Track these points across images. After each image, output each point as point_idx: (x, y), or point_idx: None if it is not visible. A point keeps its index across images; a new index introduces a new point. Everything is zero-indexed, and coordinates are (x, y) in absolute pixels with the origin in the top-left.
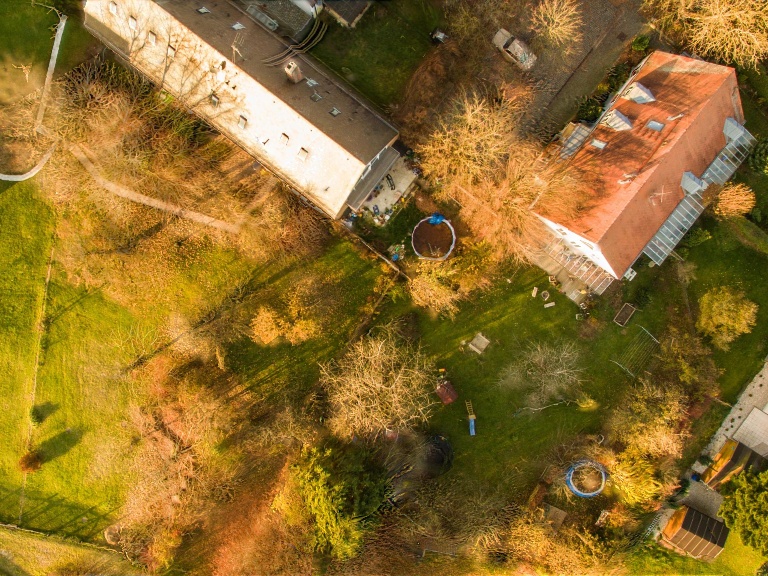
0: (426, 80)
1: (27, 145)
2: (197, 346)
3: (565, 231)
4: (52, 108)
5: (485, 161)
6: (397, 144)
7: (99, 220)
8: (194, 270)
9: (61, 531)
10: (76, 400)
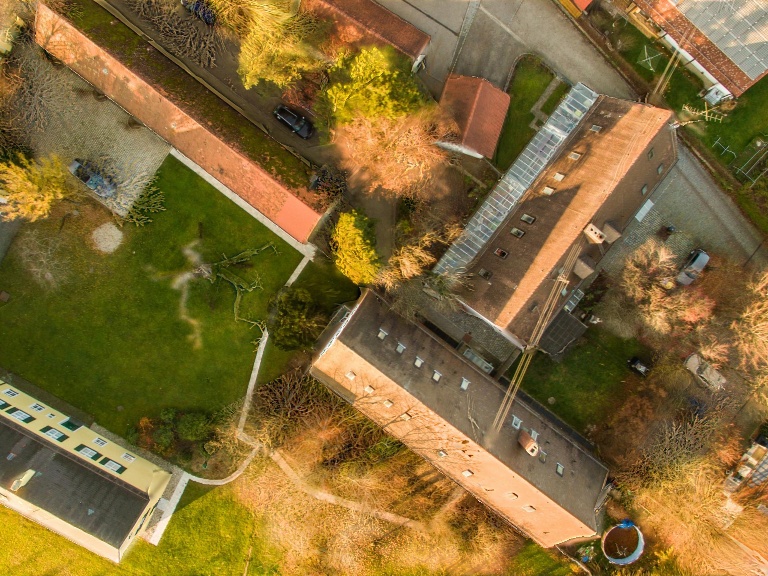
0: (638, 426)
1: (228, 452)
2: None
3: (763, 561)
4: (253, 417)
5: (677, 477)
6: (607, 482)
7: (297, 521)
8: (389, 568)
9: None
10: None
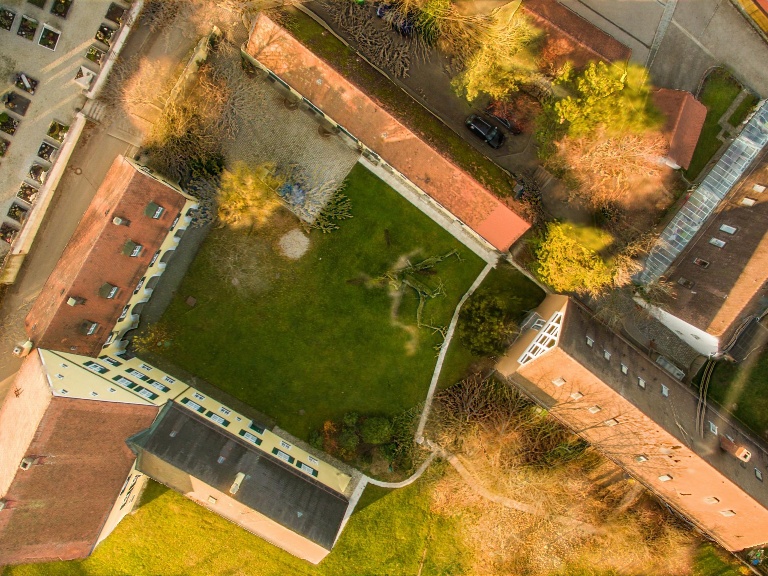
0: None
1: (407, 455)
2: None
3: None
4: (433, 421)
5: None
6: None
7: (472, 524)
8: (562, 570)
9: None
10: None
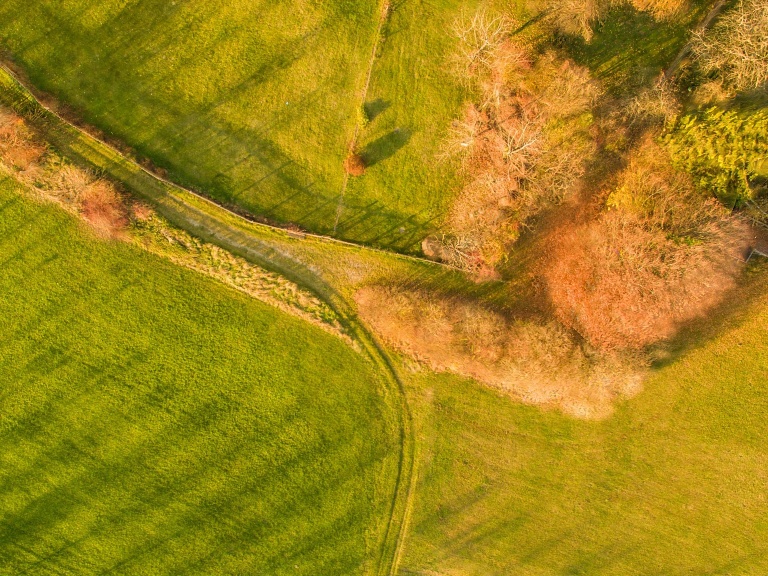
0: None
1: None
2: (542, 36)
3: None
4: None
5: None
6: None
7: None
8: None
9: (376, 243)
10: (409, 97)
